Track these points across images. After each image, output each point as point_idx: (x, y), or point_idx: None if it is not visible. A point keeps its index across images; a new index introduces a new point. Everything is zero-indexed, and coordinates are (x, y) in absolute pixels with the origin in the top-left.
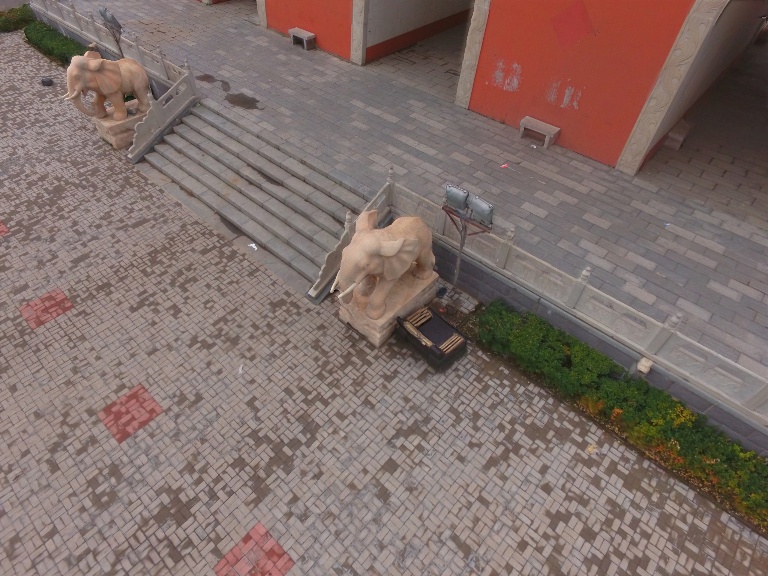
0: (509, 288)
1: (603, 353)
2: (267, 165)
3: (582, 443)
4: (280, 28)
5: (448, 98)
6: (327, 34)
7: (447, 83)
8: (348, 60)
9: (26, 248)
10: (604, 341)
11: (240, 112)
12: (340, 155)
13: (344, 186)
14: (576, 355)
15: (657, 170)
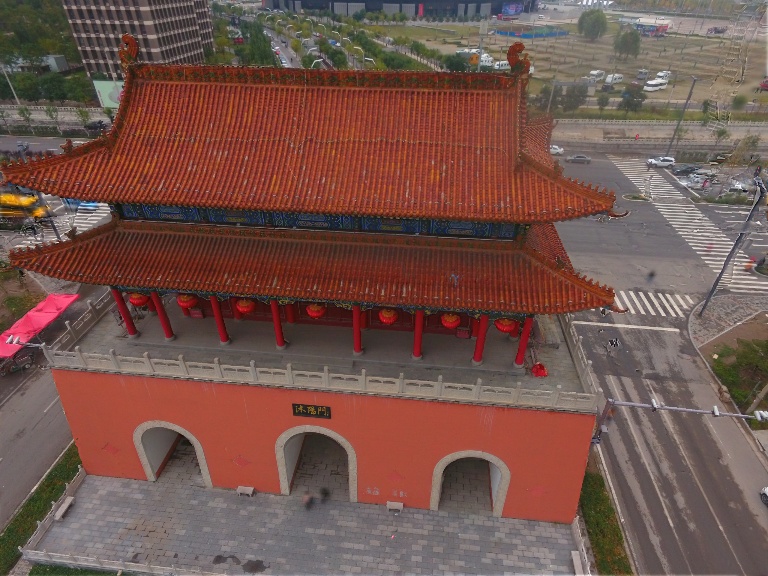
0: None
1: None
2: None
3: None
4: (224, 486)
5: (345, 499)
6: (262, 486)
7: (337, 485)
8: (280, 494)
9: None
10: None
11: None
12: None
13: None
14: None
15: (443, 500)
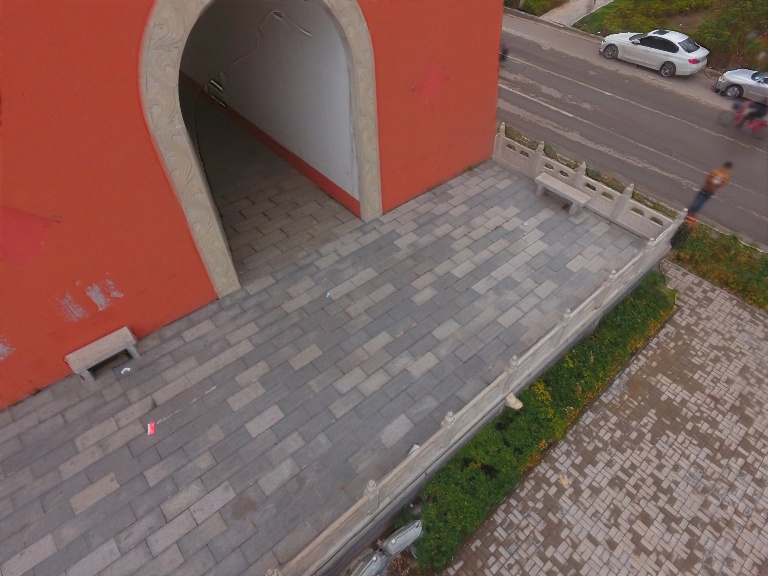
0: None
1: (482, 429)
2: None
3: (558, 487)
4: None
5: None
6: None
7: None
8: None
9: None
10: None
11: None
12: None
13: None
14: (482, 457)
15: (239, 263)
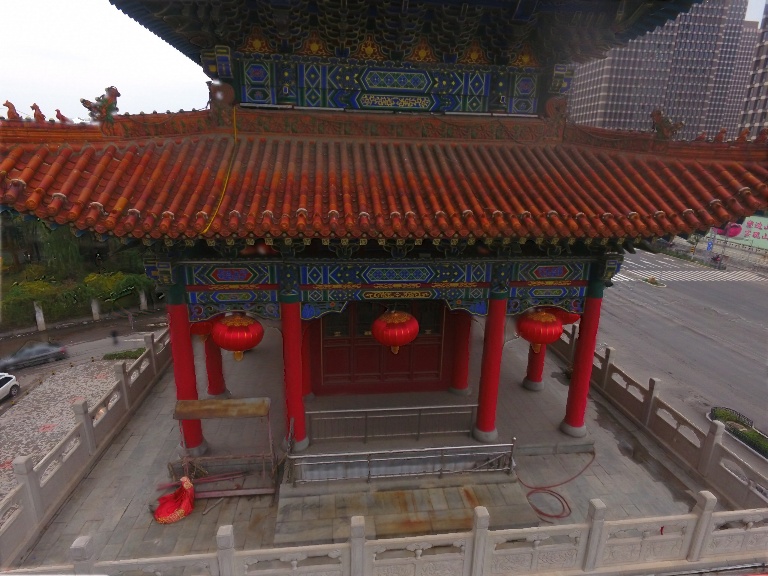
0: None
1: None
2: None
3: None
4: None
5: None
6: None
7: None
8: None
9: (2, 479)
10: None
11: None
12: None
13: None
14: None
15: None
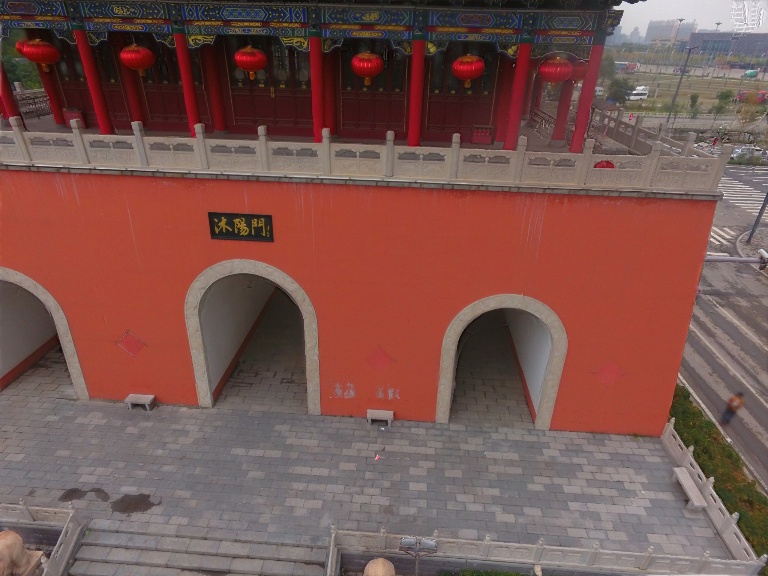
0: (445, 563)
1: (513, 572)
2: (203, 561)
3: None
4: (107, 397)
5: (300, 411)
6: (168, 393)
7: (289, 395)
8: (196, 406)
9: None
10: (512, 567)
11: (141, 519)
12: (263, 516)
13: (286, 545)
14: None
15: (455, 411)
